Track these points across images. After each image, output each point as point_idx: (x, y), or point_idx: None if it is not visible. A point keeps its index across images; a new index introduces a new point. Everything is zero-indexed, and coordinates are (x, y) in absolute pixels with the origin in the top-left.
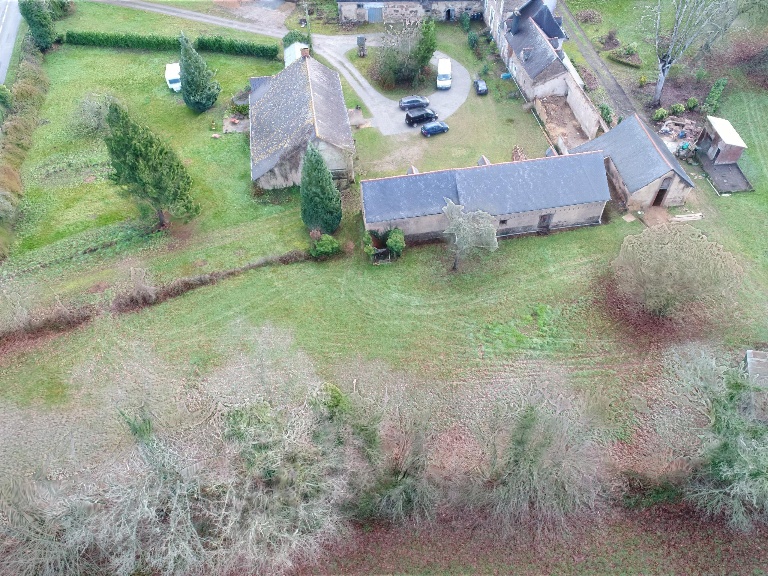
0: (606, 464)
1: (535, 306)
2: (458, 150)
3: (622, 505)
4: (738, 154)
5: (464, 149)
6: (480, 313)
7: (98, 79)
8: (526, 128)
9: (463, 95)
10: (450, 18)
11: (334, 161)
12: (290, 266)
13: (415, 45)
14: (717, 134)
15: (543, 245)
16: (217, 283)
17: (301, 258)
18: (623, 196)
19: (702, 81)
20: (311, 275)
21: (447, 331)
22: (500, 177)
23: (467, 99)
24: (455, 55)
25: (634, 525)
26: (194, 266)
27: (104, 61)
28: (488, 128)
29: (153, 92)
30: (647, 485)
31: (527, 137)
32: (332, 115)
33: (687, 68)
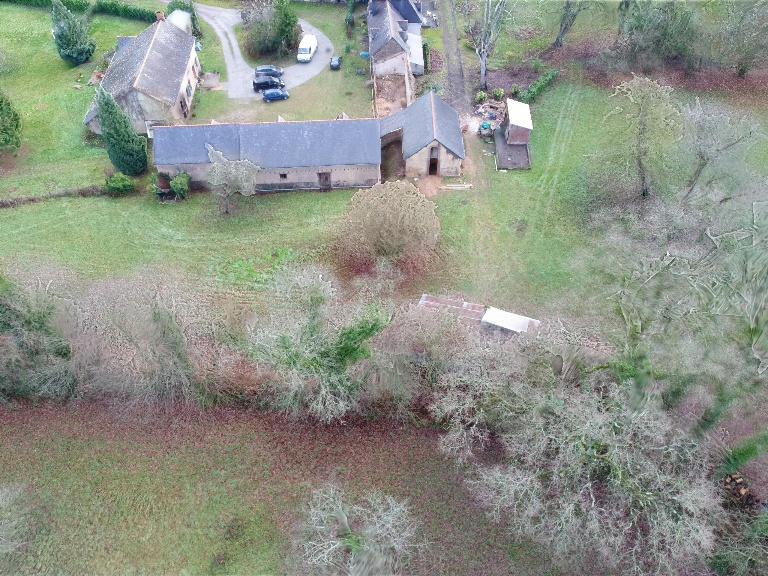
0: (265, 376)
1: (279, 248)
2: (288, 115)
3: (253, 406)
4: (526, 135)
5: (294, 115)
6: (229, 250)
7: (0, 31)
8: (359, 101)
9: (318, 69)
10: (340, 0)
11: (156, 112)
12: (87, 198)
13: (271, 18)
14: (508, 115)
15: (316, 200)
16: (17, 207)
17: (97, 192)
18: (405, 164)
19: (540, 72)
20: (101, 207)
21: (193, 262)
22: (281, 134)
23: (320, 72)
24: (330, 33)
25: (258, 424)
26: (4, 191)
27: (12, 16)
28: (325, 99)
29: (42, 46)
30: (279, 392)
31: (356, 109)
32: (165, 72)
33: (533, 59)
